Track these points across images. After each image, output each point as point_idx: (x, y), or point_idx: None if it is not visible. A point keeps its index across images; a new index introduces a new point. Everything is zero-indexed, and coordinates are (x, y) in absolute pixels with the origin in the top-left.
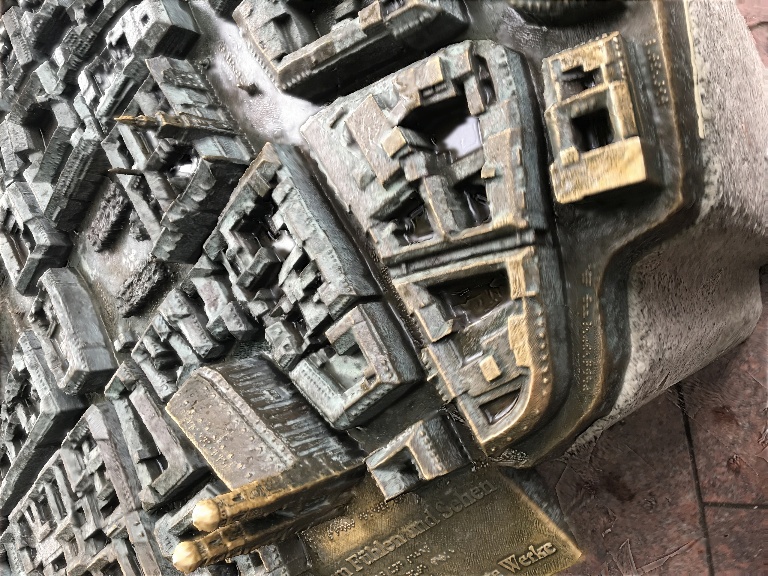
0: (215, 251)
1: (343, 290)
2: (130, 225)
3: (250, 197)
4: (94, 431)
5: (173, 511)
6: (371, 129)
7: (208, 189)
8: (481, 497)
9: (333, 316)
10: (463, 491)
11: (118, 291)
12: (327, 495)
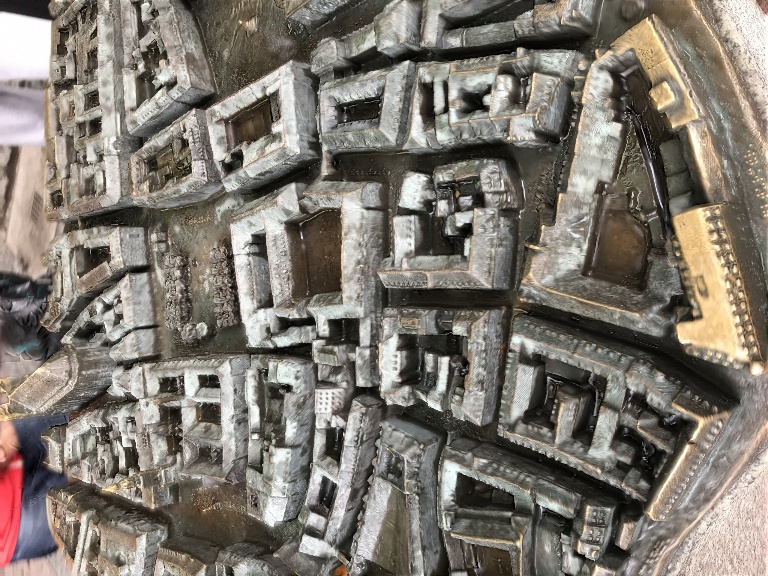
0: None
1: None
2: None
3: None
4: (100, 200)
5: None
6: (111, 574)
7: None
8: None
9: None
10: None
11: (179, 265)
12: None
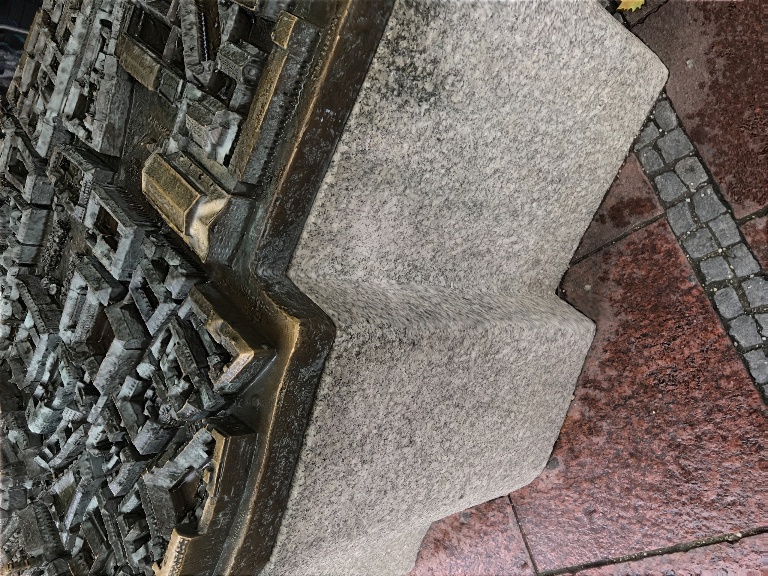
0: None
1: None
2: None
3: None
4: None
5: None
6: None
7: None
8: None
9: None
10: None
11: None
12: None
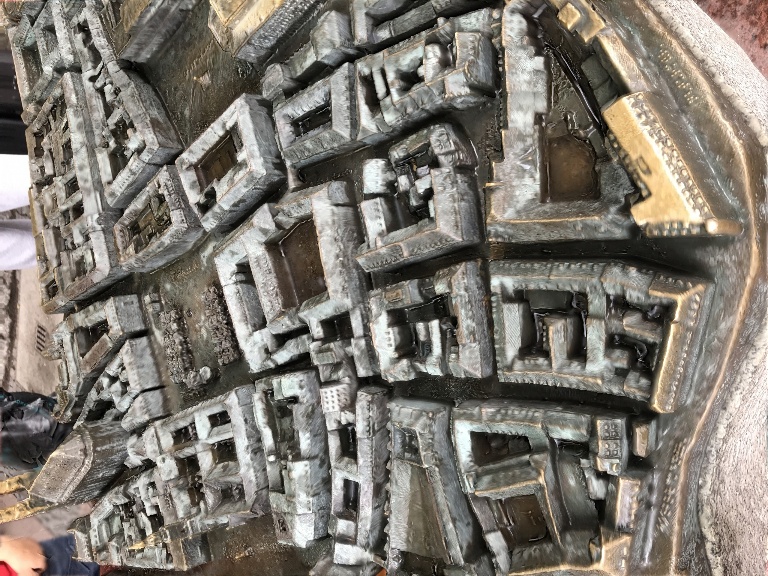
0: None
1: None
2: None
3: None
4: (92, 276)
5: None
6: None
7: None
8: None
9: None
10: None
11: (174, 318)
12: None
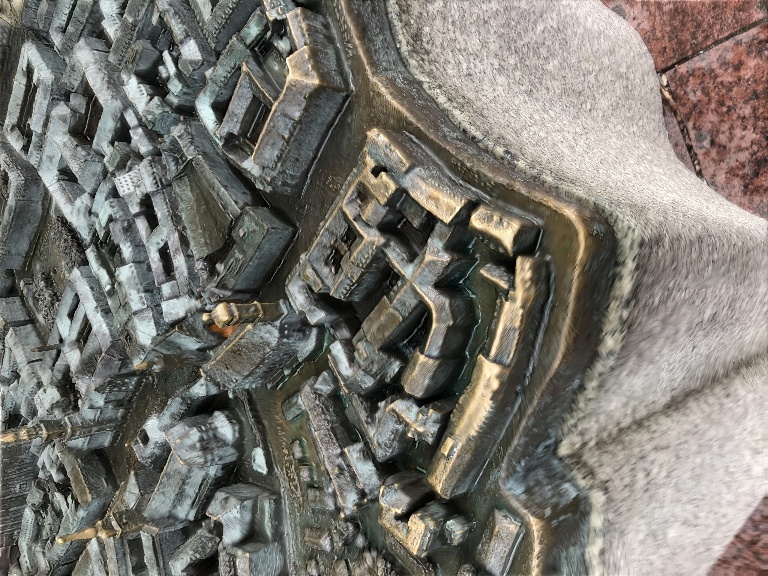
0: None
1: (52, 561)
2: None
3: None
4: None
5: None
6: None
7: None
8: None
9: None
10: None
11: (41, 278)
12: None
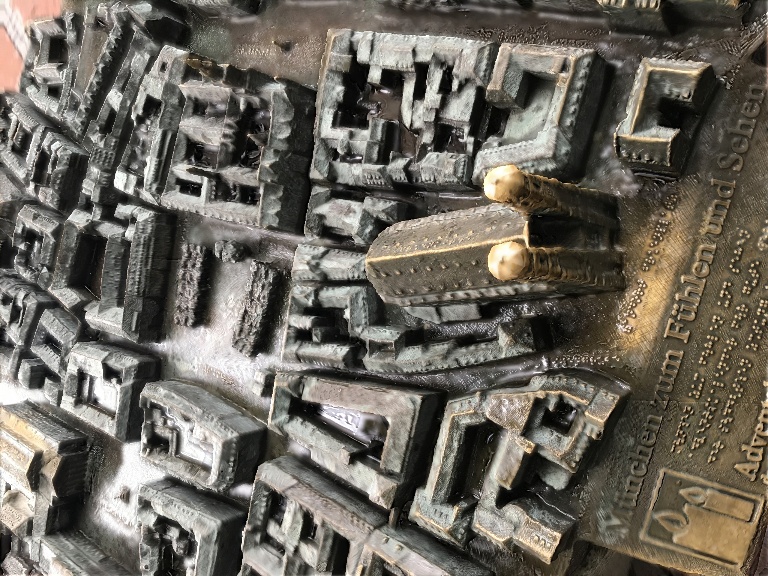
0: (325, 165)
1: (479, 46)
2: (216, 276)
3: (336, 84)
4: (277, 483)
5: (422, 486)
6: None
7: (290, 120)
8: (758, 111)
9: (483, 80)
10: (735, 121)
11: (233, 336)
12: (597, 237)
